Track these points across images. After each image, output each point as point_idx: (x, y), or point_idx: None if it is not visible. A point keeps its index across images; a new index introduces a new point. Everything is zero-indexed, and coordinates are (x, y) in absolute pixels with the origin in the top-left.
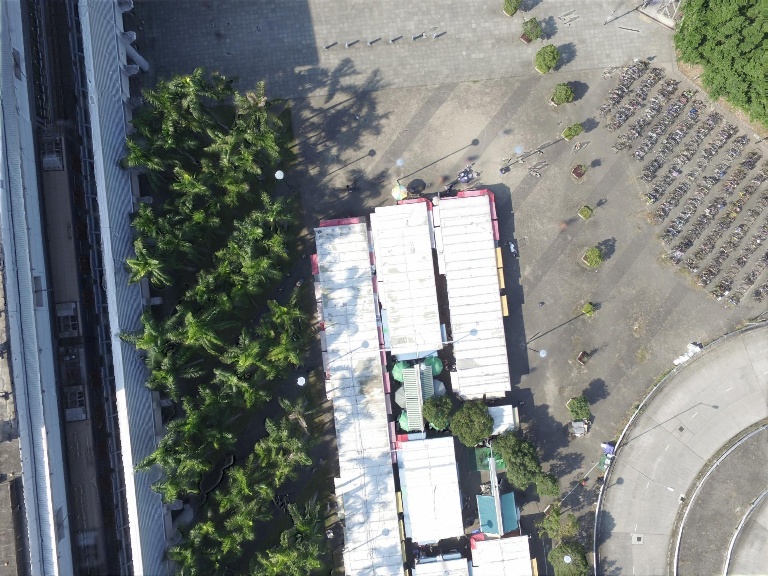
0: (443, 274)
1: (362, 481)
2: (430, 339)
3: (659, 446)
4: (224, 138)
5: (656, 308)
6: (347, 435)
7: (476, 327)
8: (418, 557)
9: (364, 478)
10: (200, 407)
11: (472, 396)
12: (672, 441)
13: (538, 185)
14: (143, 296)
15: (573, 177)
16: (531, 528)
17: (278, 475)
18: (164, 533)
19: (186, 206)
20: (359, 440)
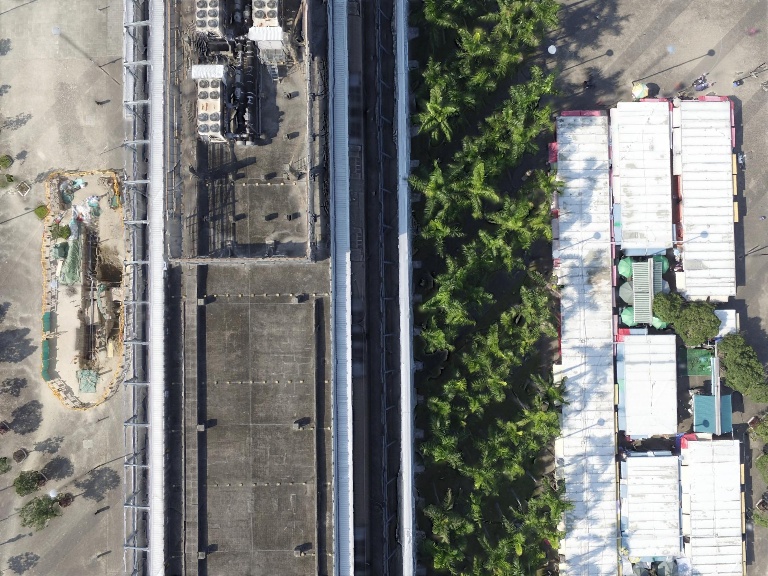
0: (678, 175)
1: (583, 369)
2: (661, 237)
3: None
4: (509, 5)
5: None
6: (572, 323)
7: (707, 230)
8: (626, 452)
9: (585, 367)
10: (466, 264)
11: (696, 298)
12: None
13: None
14: None
15: None
16: None
17: (523, 345)
18: None
19: None
20: (583, 329)
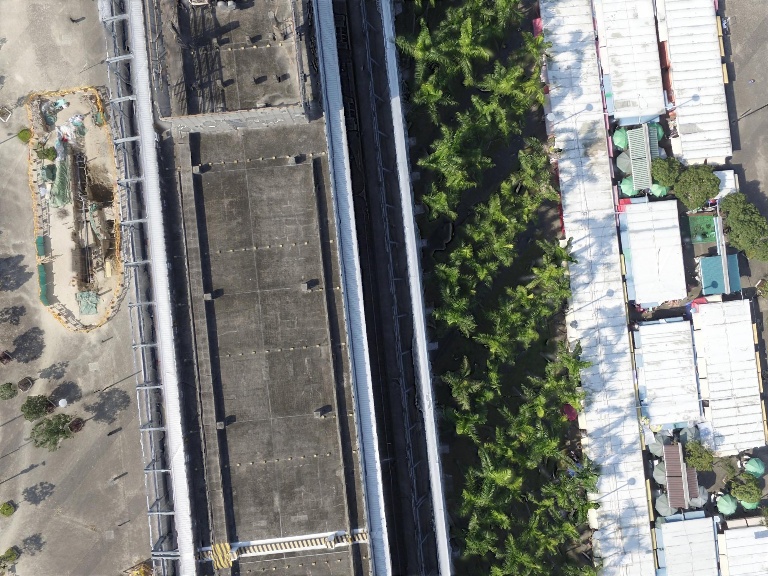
0: (664, 41)
1: (587, 242)
2: (653, 103)
3: None
4: None
5: None
6: (572, 196)
7: (698, 92)
8: (637, 323)
9: (589, 239)
10: None
11: (693, 162)
12: None
13: None
14: None
15: None
16: None
17: (526, 212)
18: None
19: None
20: (584, 201)
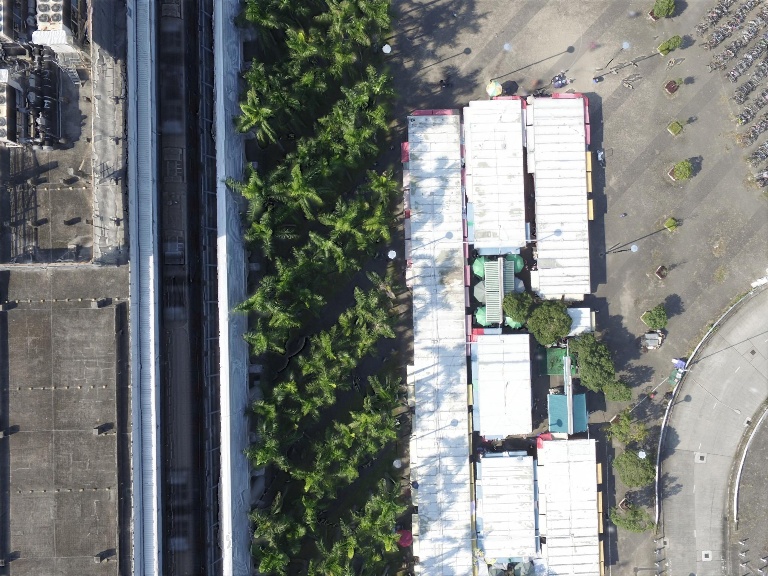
0: (531, 173)
1: (435, 370)
2: (514, 235)
3: (729, 367)
4: (338, 4)
5: (738, 229)
6: (424, 323)
7: (561, 228)
8: (483, 453)
9: (438, 367)
10: (294, 266)
11: (551, 296)
12: (743, 364)
13: (630, 97)
14: (242, 157)
15: (665, 92)
16: (596, 436)
17: (361, 346)
18: (246, 391)
19: (295, 67)
20: (435, 329)
